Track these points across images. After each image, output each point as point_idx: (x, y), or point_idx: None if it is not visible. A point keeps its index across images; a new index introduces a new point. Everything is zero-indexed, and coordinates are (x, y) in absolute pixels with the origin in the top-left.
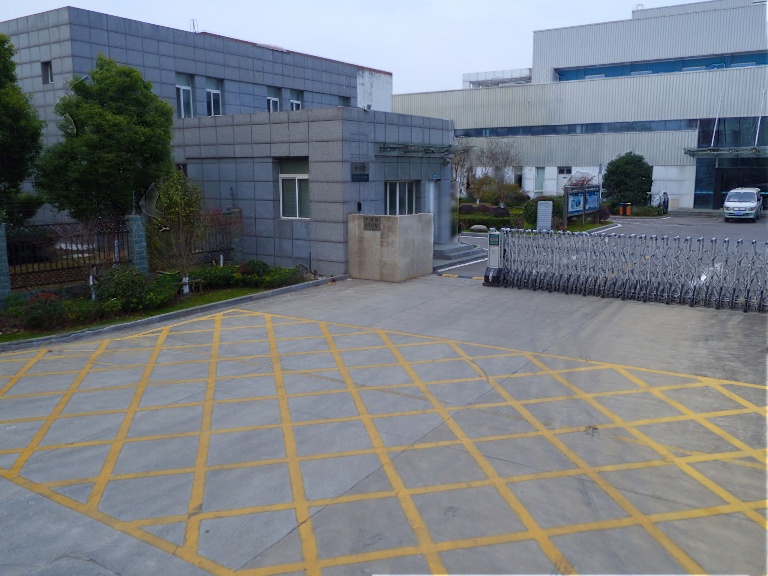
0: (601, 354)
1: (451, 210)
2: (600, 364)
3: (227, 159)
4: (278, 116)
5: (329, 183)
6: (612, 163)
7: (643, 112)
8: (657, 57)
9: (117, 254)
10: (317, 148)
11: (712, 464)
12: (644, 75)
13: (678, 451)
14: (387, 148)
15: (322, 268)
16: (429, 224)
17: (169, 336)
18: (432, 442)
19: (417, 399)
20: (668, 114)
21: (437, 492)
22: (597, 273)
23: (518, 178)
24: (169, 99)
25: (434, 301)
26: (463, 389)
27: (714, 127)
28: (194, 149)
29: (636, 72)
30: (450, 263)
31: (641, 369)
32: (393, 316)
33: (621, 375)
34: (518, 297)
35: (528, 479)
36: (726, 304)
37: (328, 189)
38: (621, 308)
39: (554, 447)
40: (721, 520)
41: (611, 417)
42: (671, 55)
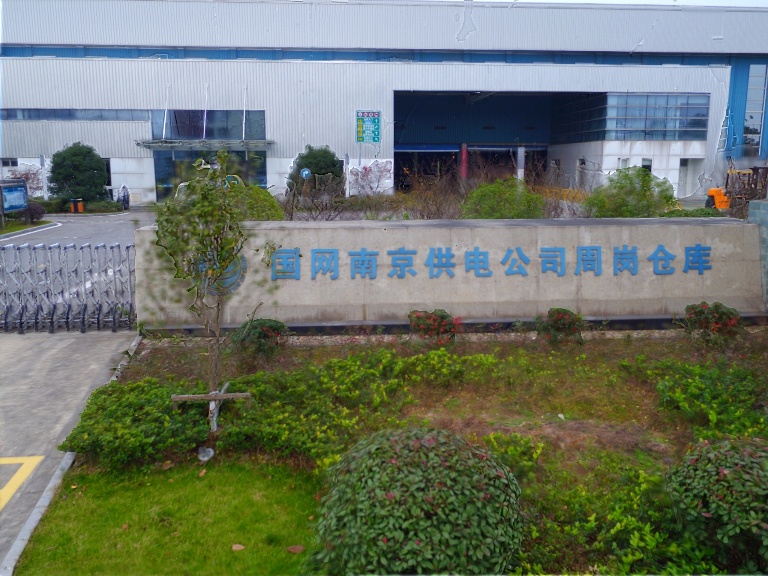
0: None
1: None
2: None
3: None
4: None
5: None
6: (58, 154)
7: (91, 99)
8: (110, 42)
9: None
10: None
11: None
12: (87, 58)
13: None
14: None
15: None
16: None
17: None
18: None
19: None
20: (118, 103)
21: None
22: None
23: None
24: None
25: None
26: None
27: (164, 119)
28: None
29: None
30: None
31: None
32: None
33: None
34: None
35: None
36: (64, 325)
37: None
38: None
39: None
40: None
41: None
42: (124, 42)
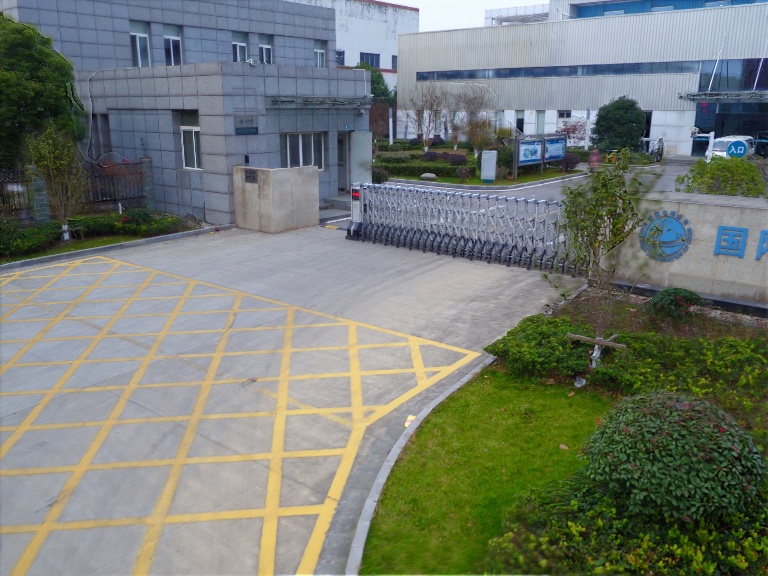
0: (357, 311)
1: (364, 161)
2: (342, 321)
3: (138, 110)
4: (173, 70)
5: (215, 136)
6: (603, 108)
7: (645, 53)
8: None
9: (17, 202)
10: (204, 102)
11: (306, 417)
12: (647, 13)
13: (294, 404)
14: (278, 101)
15: (213, 217)
16: (313, 177)
17: (13, 281)
18: (103, 386)
19: (142, 347)
20: (670, 55)
21: (50, 429)
22: (436, 230)
23: (493, 124)
24: (123, 47)
25: (280, 253)
26: (192, 340)
27: (713, 70)
28: (112, 100)
29: (657, 8)
30: (346, 214)
31: (372, 327)
32: (224, 267)
33: (346, 332)
34: (361, 251)
35: (136, 422)
36: None
37: (214, 142)
38: (440, 266)
39: (196, 395)
40: (243, 465)
41: (282, 371)
42: None
